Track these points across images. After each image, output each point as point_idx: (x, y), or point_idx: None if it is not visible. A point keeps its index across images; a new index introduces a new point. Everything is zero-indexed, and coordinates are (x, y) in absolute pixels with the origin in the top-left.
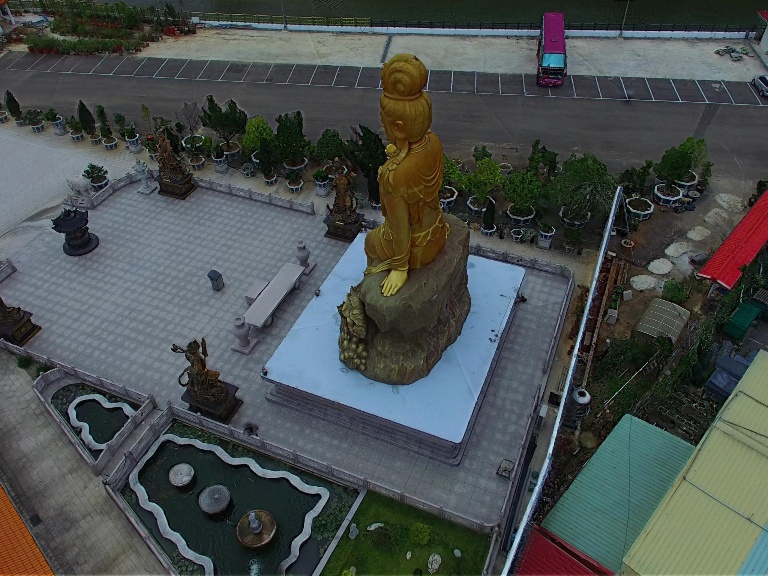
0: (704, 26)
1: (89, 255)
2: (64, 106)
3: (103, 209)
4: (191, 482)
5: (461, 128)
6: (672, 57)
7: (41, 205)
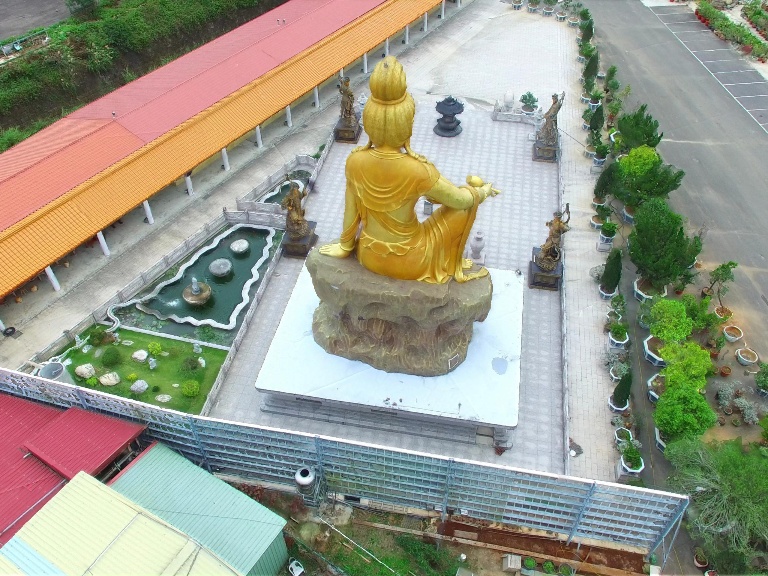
0: None
1: (438, 137)
2: (626, 59)
3: (496, 125)
4: (237, 254)
5: None
6: None
7: (488, 97)
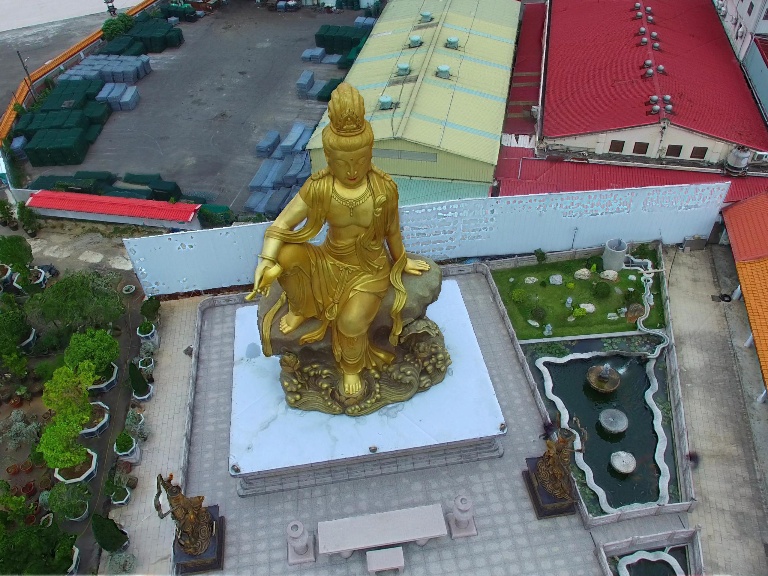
0: None
1: None
2: None
3: None
4: None
5: None
6: None
7: None
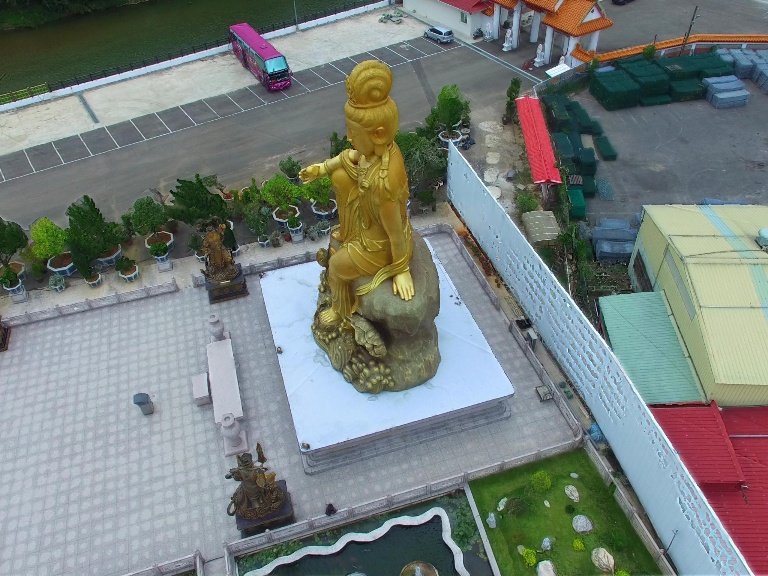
0: (357, 3)
1: None
2: None
3: None
4: None
5: (238, 153)
6: (352, 35)
7: None
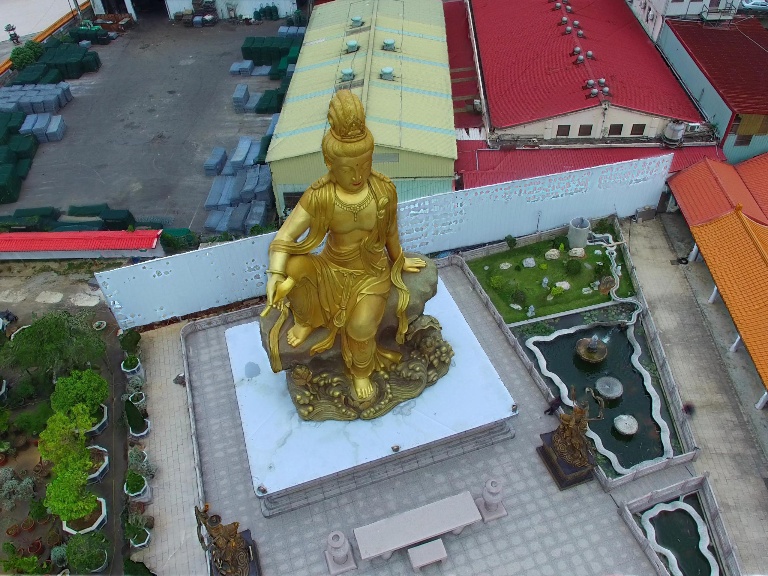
0: None
1: None
2: None
3: None
4: None
5: None
6: None
7: None
